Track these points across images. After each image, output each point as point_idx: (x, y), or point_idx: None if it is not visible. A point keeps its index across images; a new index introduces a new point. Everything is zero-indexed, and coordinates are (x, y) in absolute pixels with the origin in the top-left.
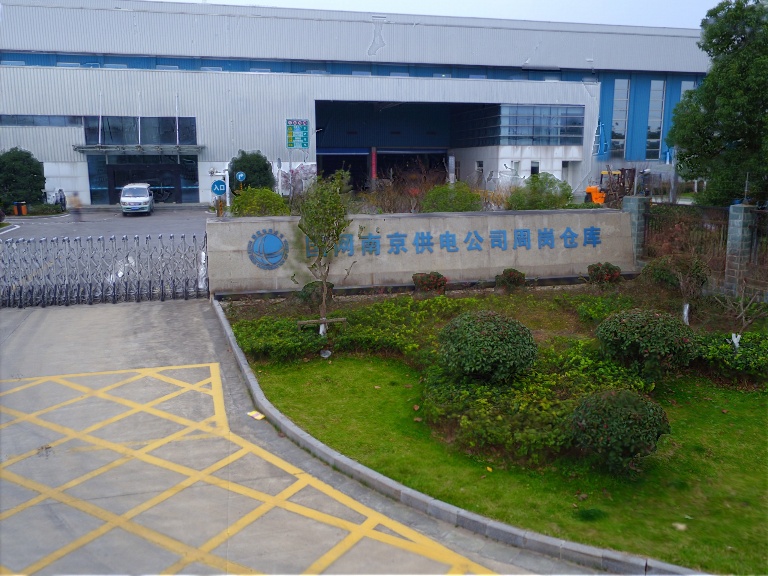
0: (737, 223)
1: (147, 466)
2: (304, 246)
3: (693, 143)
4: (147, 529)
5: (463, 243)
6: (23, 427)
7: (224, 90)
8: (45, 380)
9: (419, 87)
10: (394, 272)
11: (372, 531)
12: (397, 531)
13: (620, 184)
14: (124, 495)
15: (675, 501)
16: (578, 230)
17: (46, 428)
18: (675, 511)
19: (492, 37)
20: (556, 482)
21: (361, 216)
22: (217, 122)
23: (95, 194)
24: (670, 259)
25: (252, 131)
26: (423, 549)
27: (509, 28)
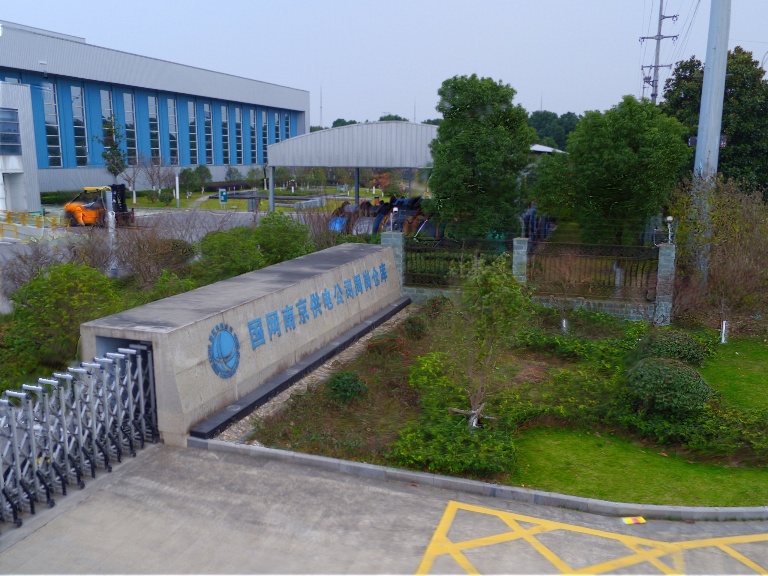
0: (522, 252)
1: None
2: (248, 336)
3: (460, 189)
4: None
5: (334, 298)
6: None
7: None
8: None
9: None
10: (306, 344)
11: None
12: None
13: None
14: None
15: None
16: (377, 268)
17: None
18: None
19: None
20: None
21: (246, 286)
22: None
23: None
24: None
25: None
26: None
27: None
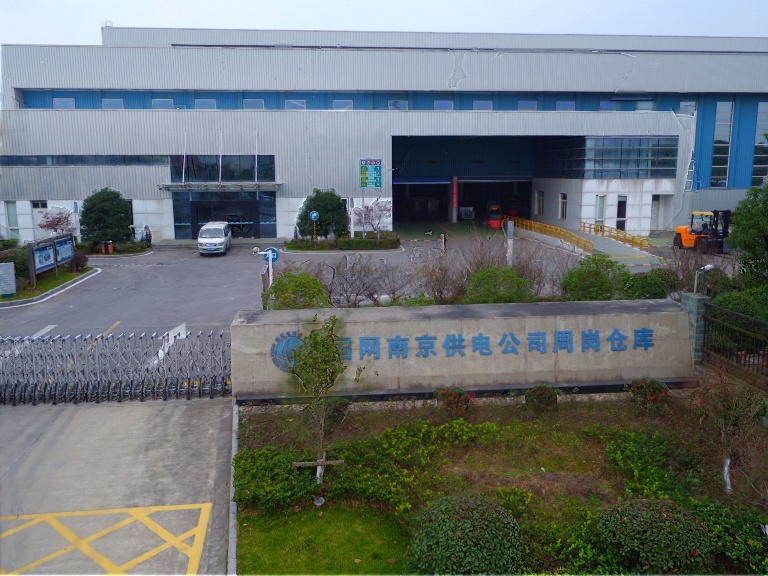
0: None
1: None
2: None
3: (756, 250)
4: None
5: (498, 346)
6: None
7: (302, 128)
8: (40, 520)
9: (499, 121)
10: (422, 376)
11: None
12: None
13: (712, 227)
14: None
15: None
16: (627, 332)
17: None
18: None
19: (581, 62)
20: None
21: (392, 313)
22: (295, 159)
23: (179, 229)
24: (701, 419)
25: (329, 167)
26: None
27: (600, 52)
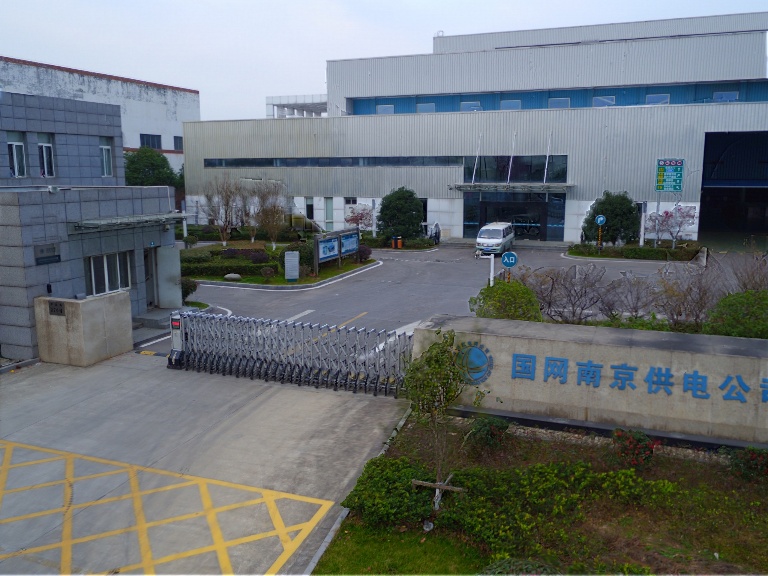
0: None
1: None
2: (510, 365)
3: None
4: None
5: (718, 389)
6: (128, 538)
7: (600, 126)
8: (195, 482)
9: None
10: (615, 411)
11: None
12: None
13: None
14: None
15: None
16: None
17: (139, 546)
18: None
19: None
20: None
21: (593, 334)
22: (589, 159)
23: (469, 228)
24: None
25: (627, 168)
26: None
27: None
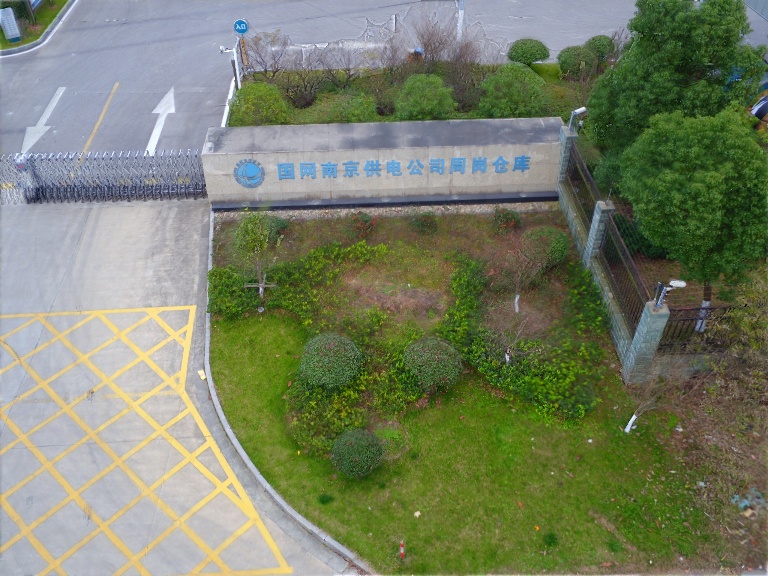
0: (597, 218)
1: (137, 418)
2: (277, 171)
3: None
4: (130, 470)
5: (406, 169)
6: (81, 369)
7: None
8: (94, 316)
9: None
10: (348, 190)
11: (226, 488)
12: (237, 490)
13: None
14: (124, 441)
15: (371, 496)
16: (510, 158)
17: (92, 372)
18: (366, 503)
19: None
20: (326, 469)
21: (328, 136)
22: None
23: None
24: None
25: None
26: (242, 505)
27: None
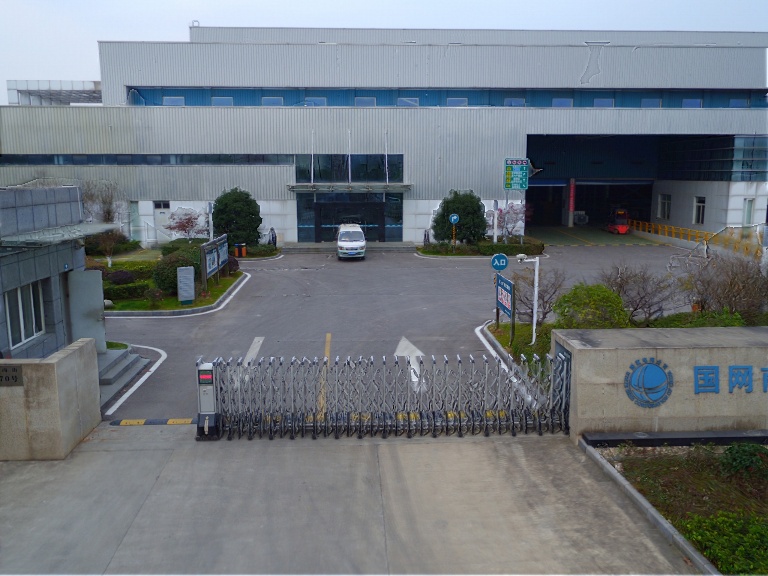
0: None
1: None
2: (692, 379)
3: None
4: None
5: None
6: None
7: (433, 126)
8: None
9: (642, 118)
10: None
11: None
12: None
13: None
14: None
15: None
16: None
17: None
18: None
19: (713, 57)
20: None
21: (747, 335)
22: (425, 159)
23: (301, 231)
24: None
25: (460, 168)
26: None
27: (734, 46)
